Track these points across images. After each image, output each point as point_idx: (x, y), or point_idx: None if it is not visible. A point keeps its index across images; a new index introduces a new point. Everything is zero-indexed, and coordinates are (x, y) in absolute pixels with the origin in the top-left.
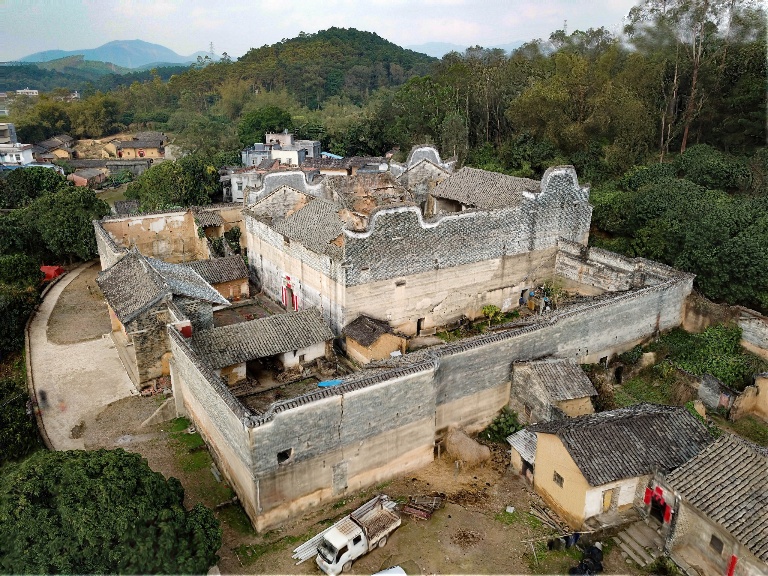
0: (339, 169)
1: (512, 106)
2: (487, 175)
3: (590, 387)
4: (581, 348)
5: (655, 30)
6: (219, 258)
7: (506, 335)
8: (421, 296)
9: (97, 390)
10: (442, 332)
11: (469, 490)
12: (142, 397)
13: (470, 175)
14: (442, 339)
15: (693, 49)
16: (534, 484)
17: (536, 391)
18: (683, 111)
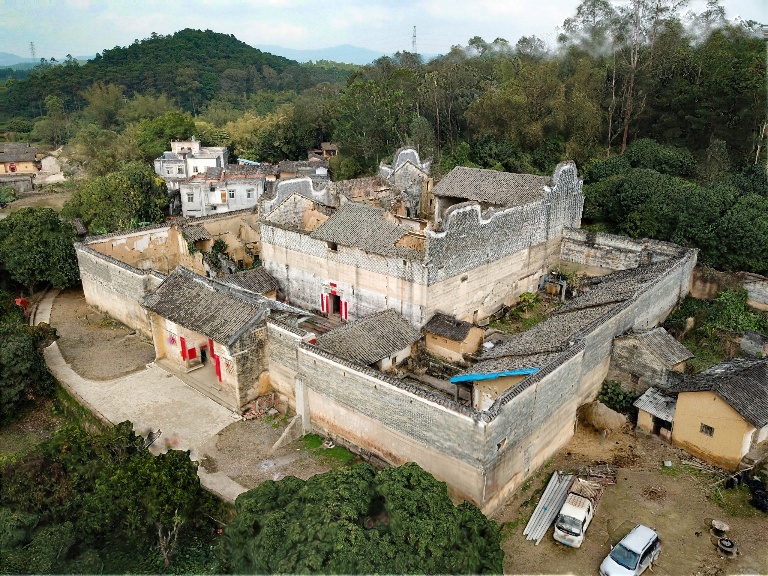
0: (267, 175)
1: (470, 108)
2: (485, 173)
3: (686, 350)
4: (645, 320)
5: (593, 39)
6: (244, 272)
7: (613, 313)
8: (477, 289)
9: (193, 421)
10: (489, 322)
11: (620, 454)
12: (248, 421)
13: (467, 174)
14: (494, 328)
15: (631, 56)
16: (672, 439)
17: (646, 360)
18: (628, 110)
